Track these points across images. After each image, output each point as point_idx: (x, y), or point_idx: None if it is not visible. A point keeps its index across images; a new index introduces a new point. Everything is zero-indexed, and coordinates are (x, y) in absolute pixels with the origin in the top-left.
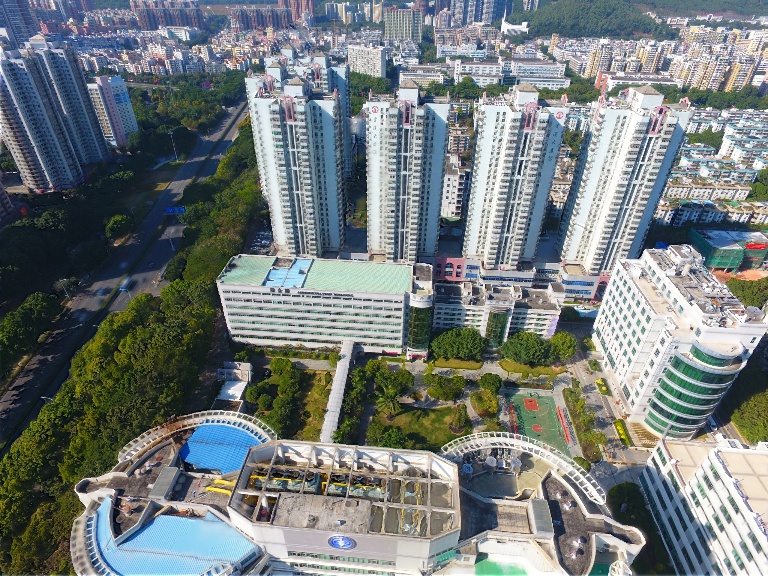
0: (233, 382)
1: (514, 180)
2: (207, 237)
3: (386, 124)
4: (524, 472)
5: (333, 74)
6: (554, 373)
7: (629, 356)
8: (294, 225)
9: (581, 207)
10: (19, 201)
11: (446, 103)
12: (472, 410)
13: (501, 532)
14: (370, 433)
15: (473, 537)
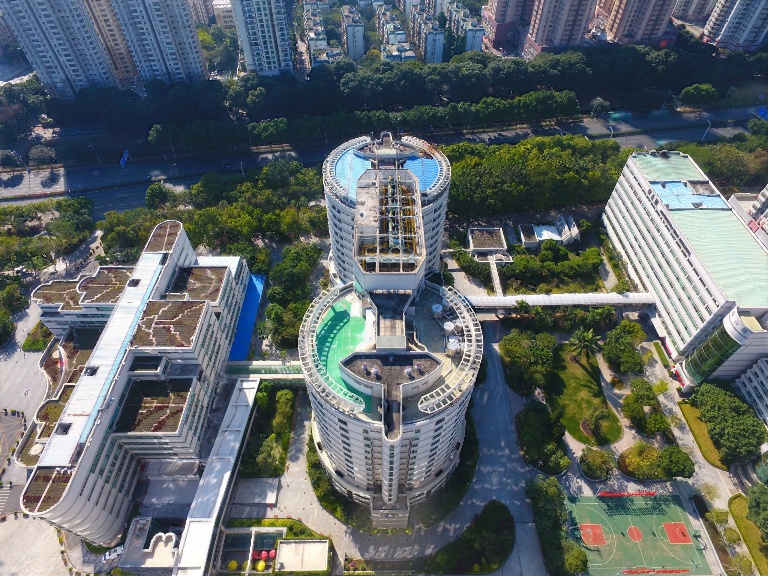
0: (556, 231)
1: None
2: (732, 146)
3: None
4: (450, 360)
5: None
6: None
7: None
8: None
9: None
10: (677, 37)
11: None
12: (626, 447)
13: None
14: (541, 336)
15: None
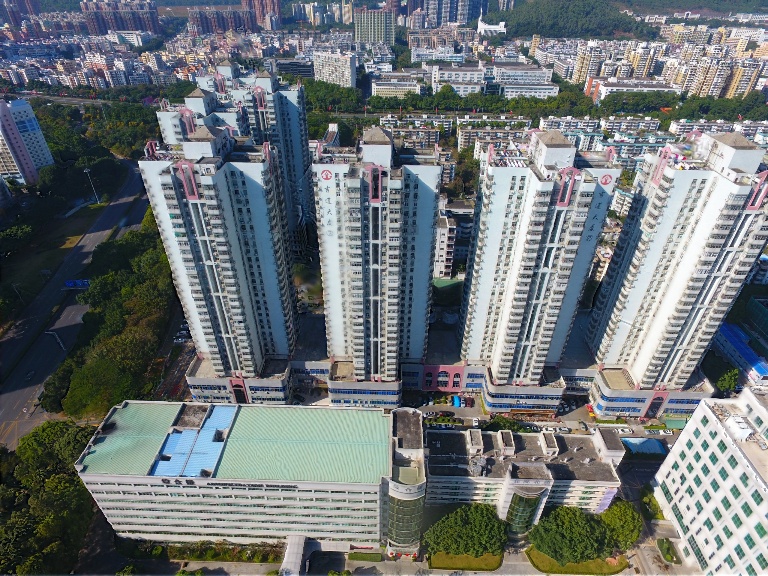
0: None
1: (538, 274)
2: (107, 335)
3: (344, 195)
4: None
5: (282, 99)
6: (611, 571)
7: (740, 573)
8: (217, 335)
9: (629, 300)
10: None
11: (434, 164)
12: None
13: None
14: None
15: None
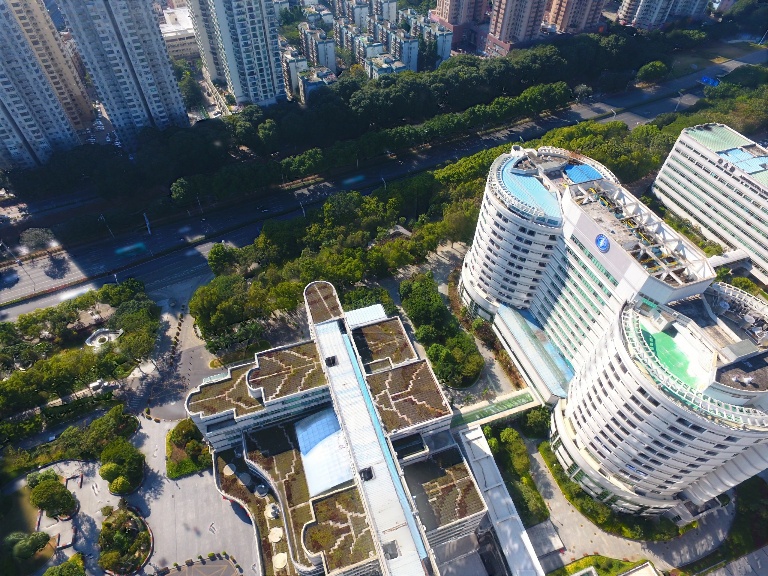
0: None
1: None
2: (713, 111)
3: None
4: None
5: None
6: None
7: None
8: None
9: None
10: None
11: None
12: None
13: (700, 328)
14: None
15: (678, 312)
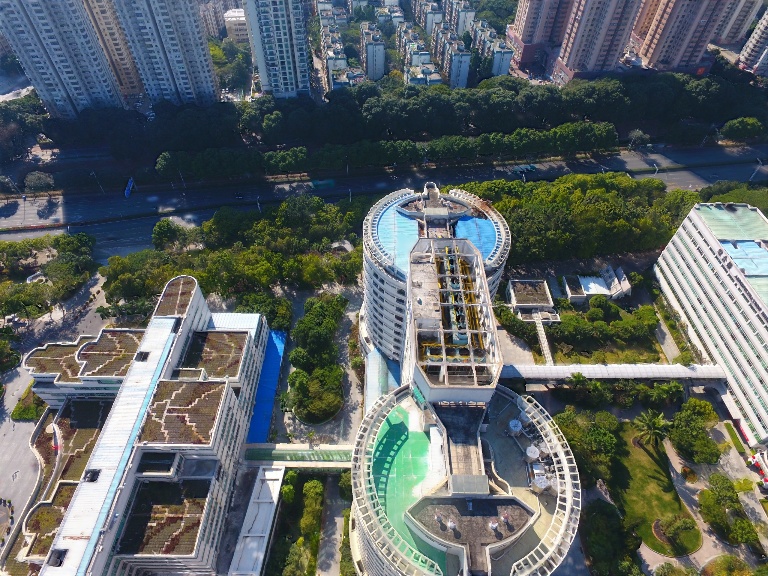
0: (604, 283)
1: None
2: None
3: None
4: (537, 498)
5: None
6: None
7: None
8: None
9: None
10: (713, 63)
11: None
12: (707, 558)
13: None
14: (600, 415)
15: None
